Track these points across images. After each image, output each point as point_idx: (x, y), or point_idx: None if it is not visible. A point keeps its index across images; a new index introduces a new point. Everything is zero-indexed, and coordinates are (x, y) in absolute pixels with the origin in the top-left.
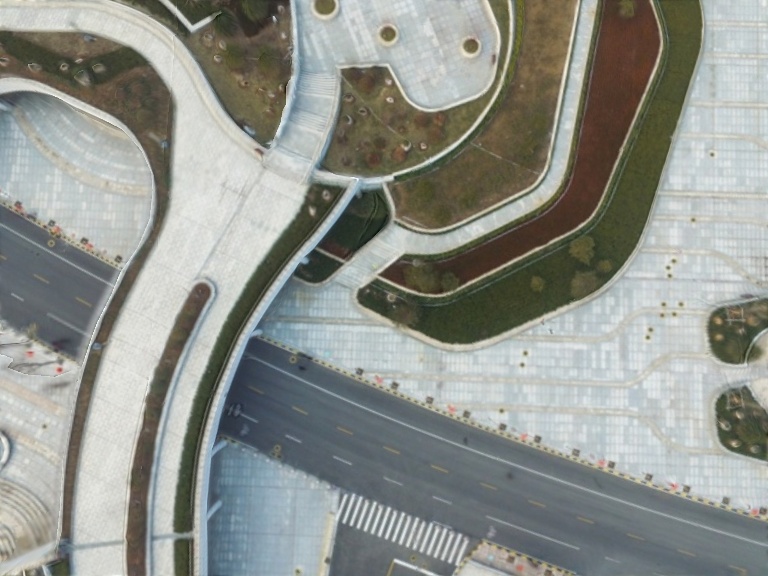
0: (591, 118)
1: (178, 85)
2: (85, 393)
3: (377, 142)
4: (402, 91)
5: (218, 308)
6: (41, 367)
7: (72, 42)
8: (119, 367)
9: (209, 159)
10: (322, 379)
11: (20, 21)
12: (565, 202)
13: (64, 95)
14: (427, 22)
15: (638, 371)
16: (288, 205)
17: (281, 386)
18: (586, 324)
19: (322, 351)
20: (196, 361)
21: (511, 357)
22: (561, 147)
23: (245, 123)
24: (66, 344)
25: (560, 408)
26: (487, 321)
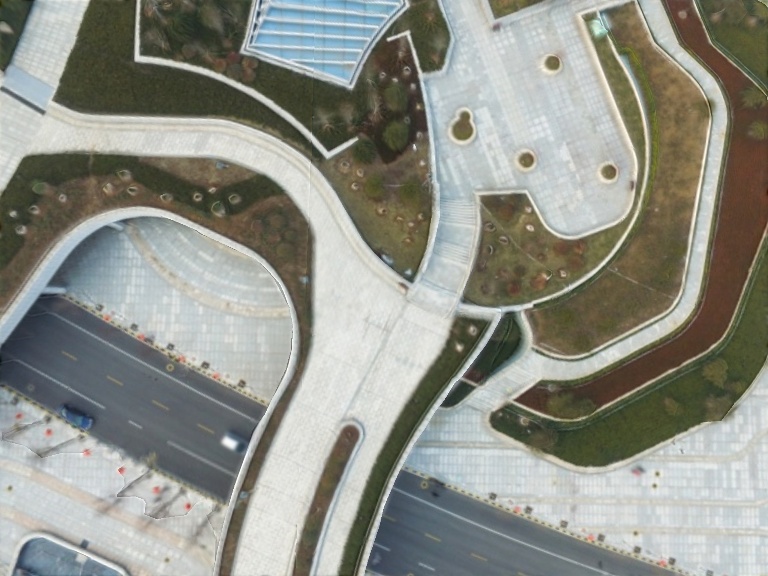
0: (722, 240)
1: (316, 215)
2: (231, 543)
3: (517, 270)
4: (541, 218)
5: (366, 450)
6: (172, 506)
7: (202, 168)
8: (266, 515)
9: (351, 293)
10: (455, 504)
11: (146, 145)
12: (698, 324)
13: (197, 226)
14: (563, 146)
15: (767, 490)
16: (433, 340)
17: (413, 513)
18: (716, 443)
19: (454, 476)
20: (346, 506)
21: (643, 478)
22: (694, 270)
23: (383, 252)
24: (188, 473)
25: (693, 529)
26: (621, 444)
